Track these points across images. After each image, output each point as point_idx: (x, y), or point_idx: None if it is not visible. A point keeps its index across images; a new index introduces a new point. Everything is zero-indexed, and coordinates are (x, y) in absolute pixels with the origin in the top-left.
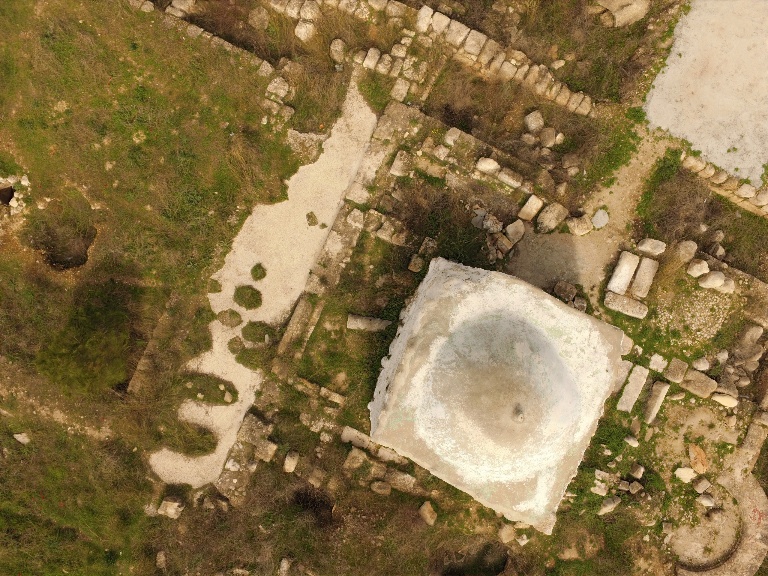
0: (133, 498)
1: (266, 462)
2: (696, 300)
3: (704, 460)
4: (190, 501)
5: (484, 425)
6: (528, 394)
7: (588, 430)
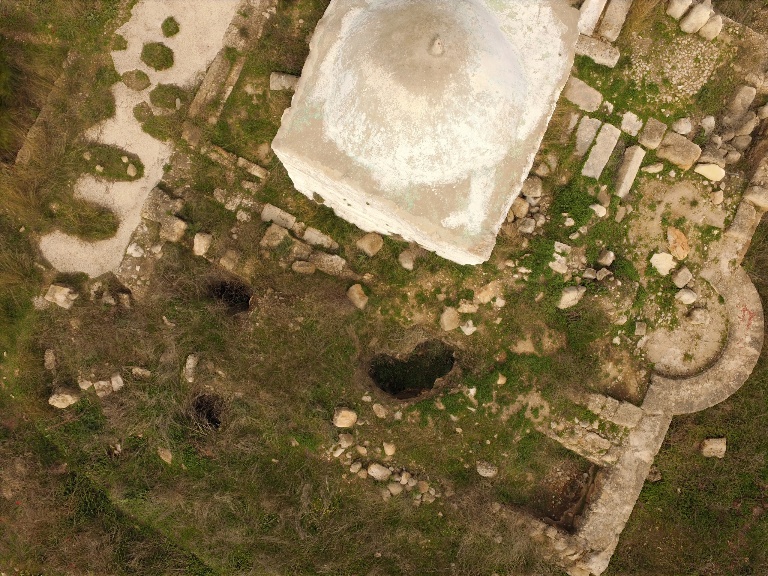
0: (18, 285)
1: (172, 242)
2: (677, 49)
3: (685, 244)
4: (86, 292)
5: (395, 68)
6: (450, 26)
7: (535, 126)
